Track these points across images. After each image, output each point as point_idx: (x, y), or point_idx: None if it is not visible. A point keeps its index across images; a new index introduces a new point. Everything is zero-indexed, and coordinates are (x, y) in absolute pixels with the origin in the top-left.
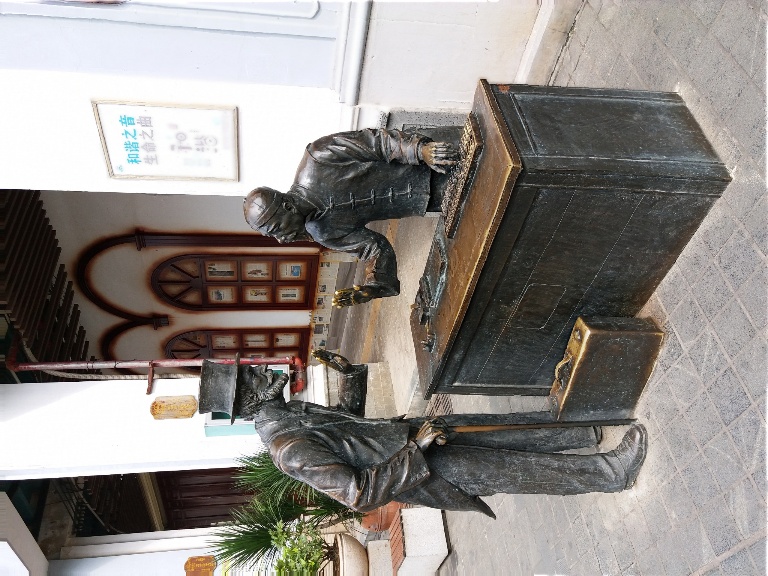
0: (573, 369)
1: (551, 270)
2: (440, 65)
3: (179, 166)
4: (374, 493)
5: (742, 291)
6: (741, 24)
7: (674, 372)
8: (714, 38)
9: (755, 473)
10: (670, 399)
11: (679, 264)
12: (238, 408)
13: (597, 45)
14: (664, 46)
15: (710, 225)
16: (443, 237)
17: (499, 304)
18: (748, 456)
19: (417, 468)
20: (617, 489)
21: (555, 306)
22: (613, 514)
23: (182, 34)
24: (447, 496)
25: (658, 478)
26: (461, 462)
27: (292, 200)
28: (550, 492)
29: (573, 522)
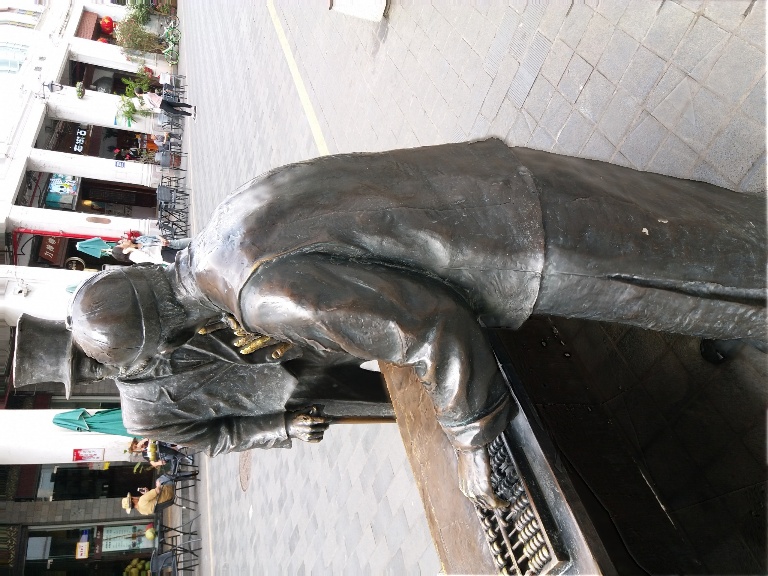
0: None
1: None
2: None
3: None
4: None
5: None
6: None
7: None
8: None
9: None
10: None
11: None
12: None
13: None
14: None
15: None
16: None
17: None
18: None
19: None
20: None
21: None
22: None
23: None
24: None
25: None
26: None
27: (185, 318)
28: None
29: None
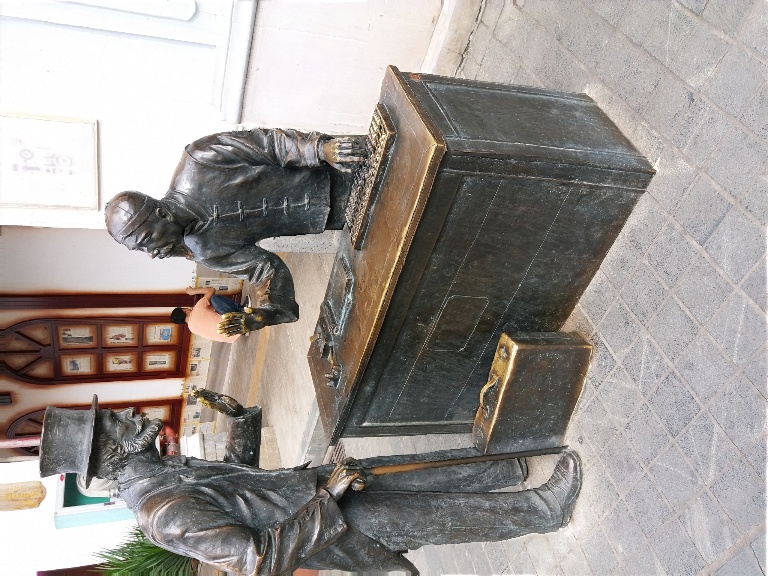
0: (500, 392)
1: (473, 278)
2: (331, 83)
3: (23, 191)
4: (279, 558)
5: (678, 287)
6: (651, 16)
7: (607, 387)
8: (623, 35)
9: (714, 486)
10: (605, 418)
11: (603, 270)
12: (96, 465)
13: (494, 62)
14: (568, 51)
15: (635, 223)
16: (347, 252)
17: (416, 322)
18: (703, 468)
19: (331, 521)
20: (553, 528)
21: (476, 322)
22: (547, 559)
23: (28, 29)
24: (367, 555)
25: (598, 509)
26: (381, 511)
27: (167, 207)
28: (482, 538)
29: (499, 575)
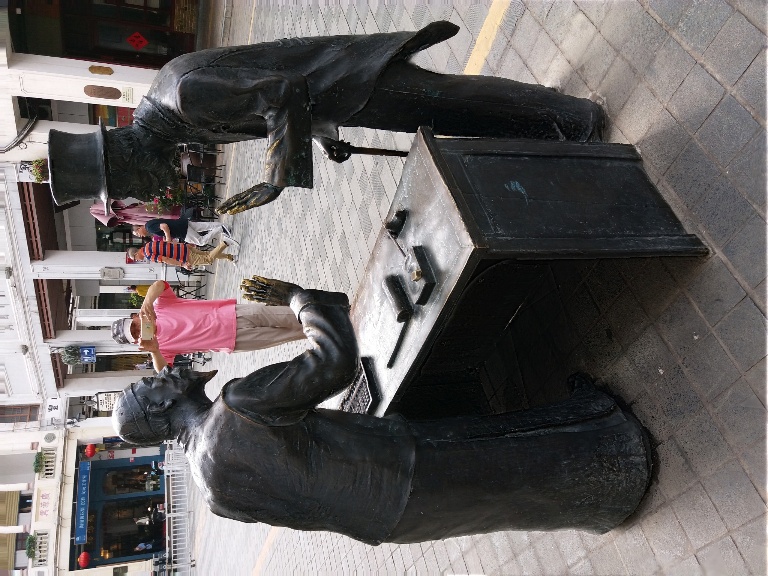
0: None
1: None
2: None
3: None
4: None
5: None
6: None
7: None
8: None
9: None
10: None
11: None
12: None
13: None
14: None
15: None
16: (387, 369)
17: None
18: None
19: None
20: None
21: None
22: (569, 41)
23: None
24: None
25: None
26: None
27: None
28: None
29: None
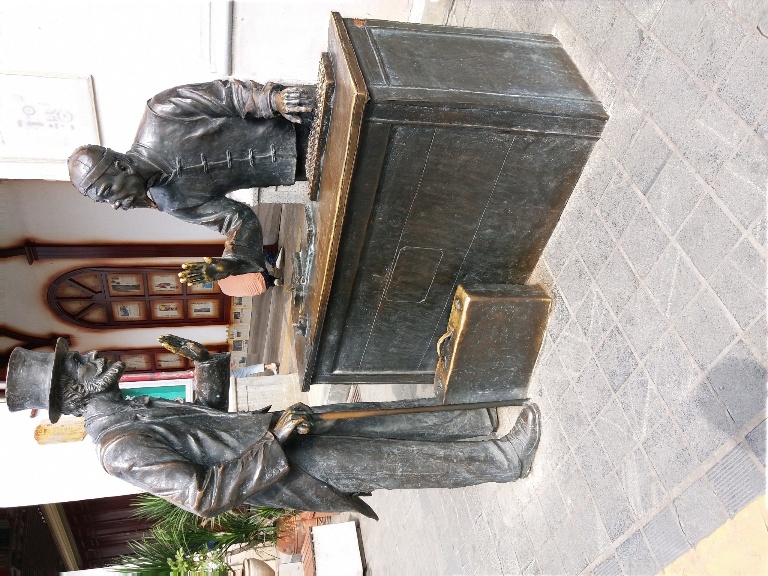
0: (455, 343)
1: (423, 229)
2: (320, 31)
3: (31, 146)
4: (219, 494)
5: (624, 239)
6: None
7: (563, 340)
8: None
9: (645, 441)
10: (560, 371)
11: (563, 221)
12: (58, 402)
13: (480, 3)
14: None
15: (590, 172)
16: (311, 204)
17: (370, 273)
18: (638, 423)
19: (273, 462)
20: (511, 478)
21: (434, 274)
22: (512, 508)
23: None
24: (314, 495)
25: (552, 461)
26: (330, 454)
27: (129, 160)
28: (436, 485)
29: (475, 522)
